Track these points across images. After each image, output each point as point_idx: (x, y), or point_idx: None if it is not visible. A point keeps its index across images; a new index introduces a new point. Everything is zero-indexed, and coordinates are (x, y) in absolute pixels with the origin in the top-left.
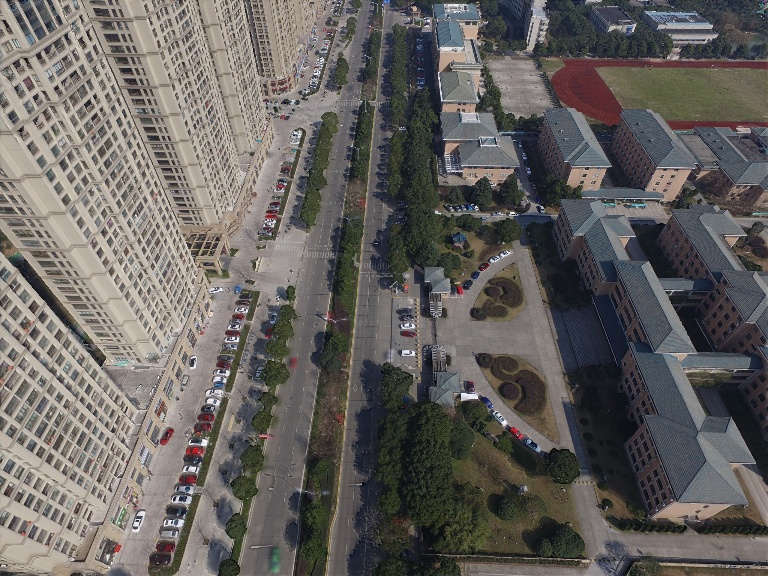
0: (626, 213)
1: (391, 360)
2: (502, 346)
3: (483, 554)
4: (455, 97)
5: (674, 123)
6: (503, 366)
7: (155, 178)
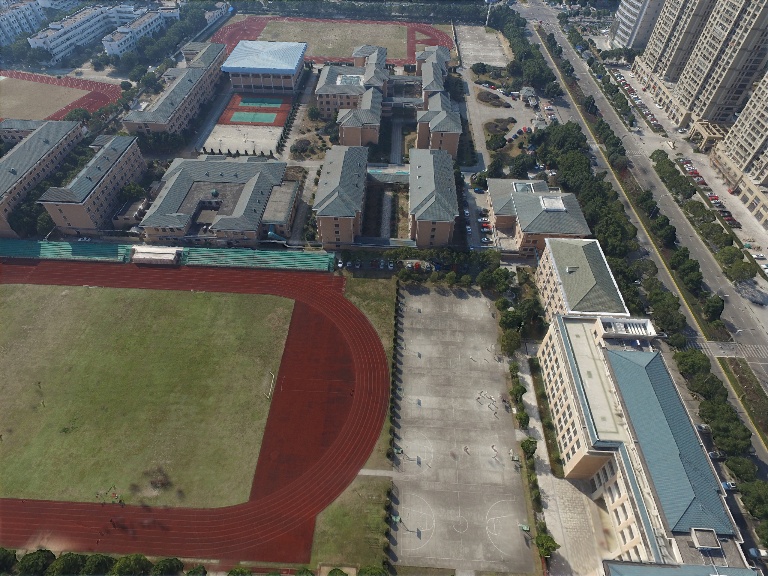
0: (387, 171)
1: None
2: (498, 110)
3: None
4: (581, 241)
5: (238, 286)
6: (498, 103)
7: (742, 42)
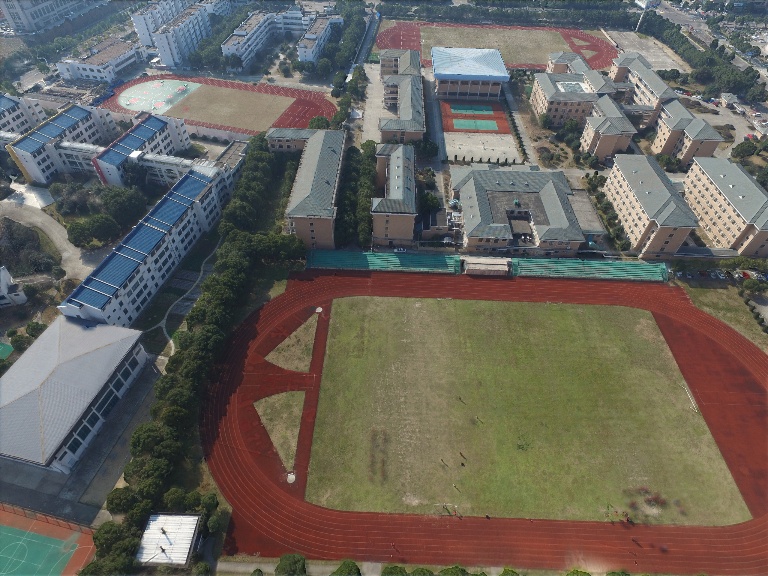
0: None
1: (763, 114)
2: None
3: (688, 75)
4: None
5: (584, 298)
6: None
7: None
